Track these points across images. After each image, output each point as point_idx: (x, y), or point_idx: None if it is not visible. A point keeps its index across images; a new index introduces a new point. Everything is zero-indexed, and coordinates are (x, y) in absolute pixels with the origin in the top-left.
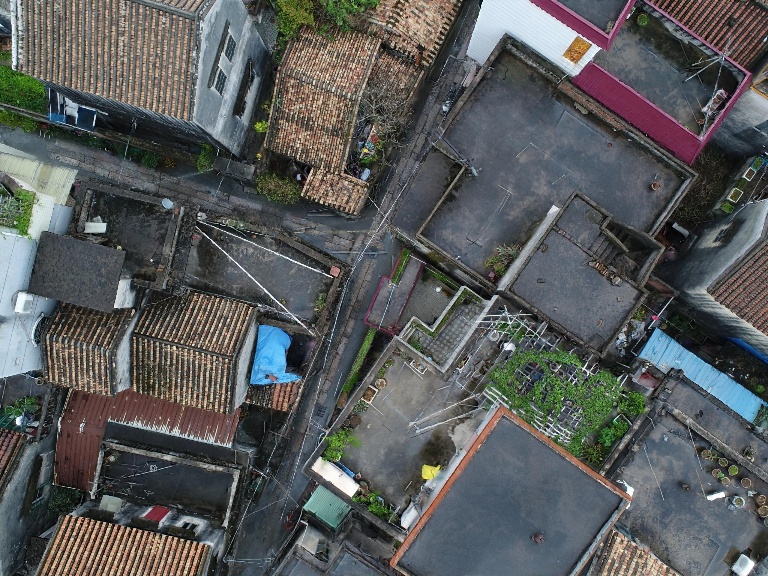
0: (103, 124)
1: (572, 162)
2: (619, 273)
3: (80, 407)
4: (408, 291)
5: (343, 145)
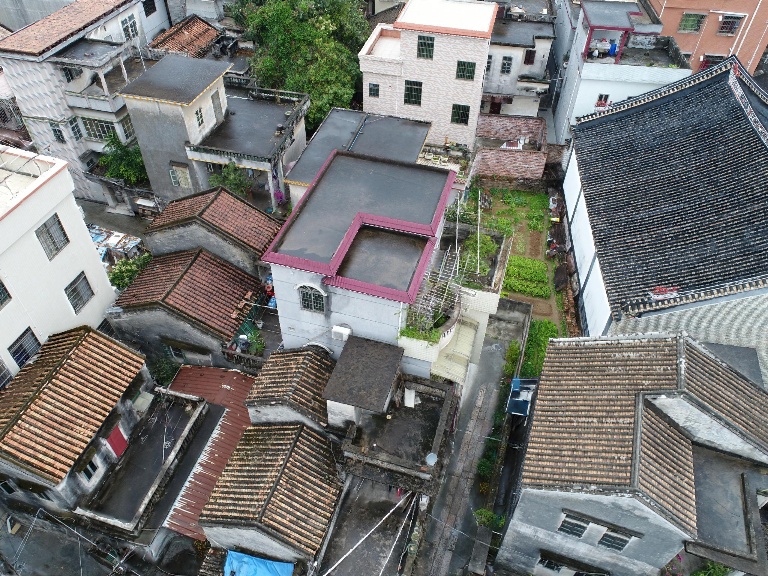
0: (515, 422)
1: None
2: None
3: (246, 387)
4: None
5: None
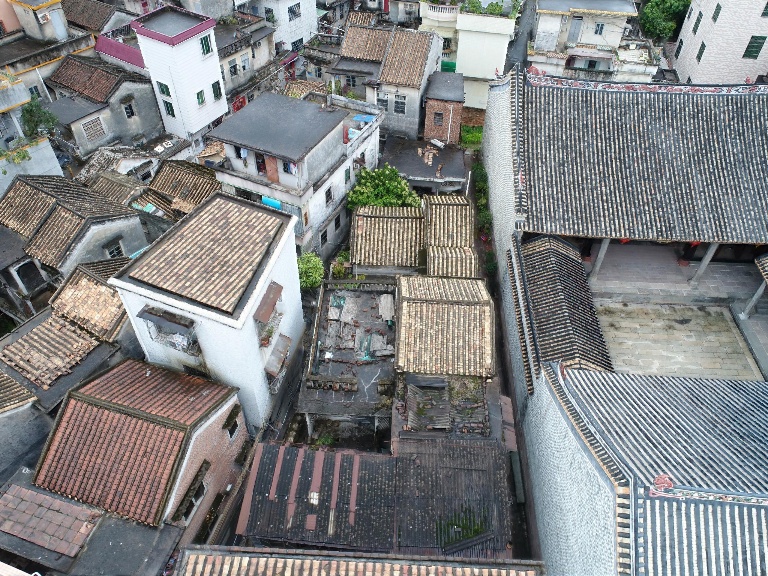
0: None
1: None
2: None
3: None
4: None
5: None
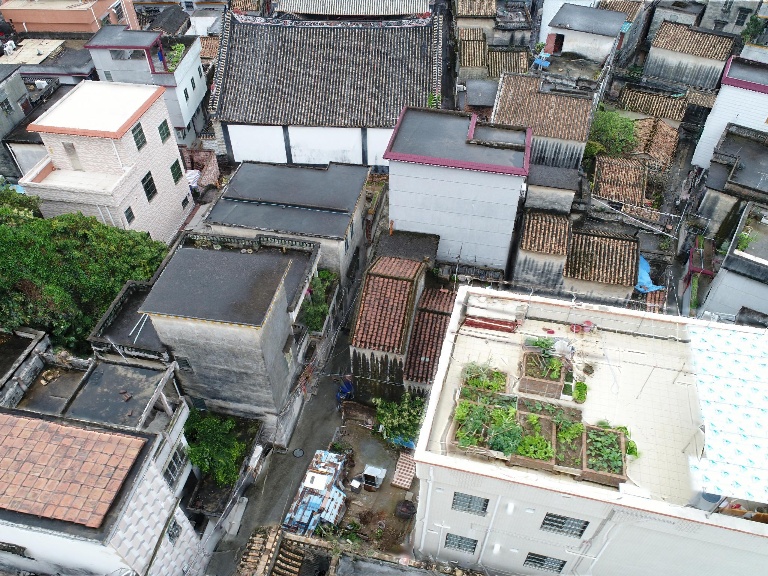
0: None
1: None
2: None
3: None
4: (711, 254)
5: (641, 191)
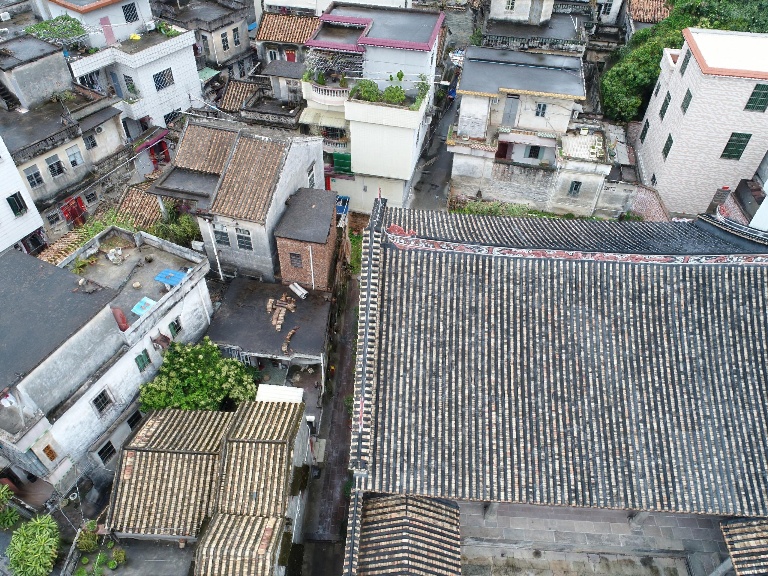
0: None
1: (1, 126)
2: (1, 50)
3: None
4: (138, 139)
5: None
